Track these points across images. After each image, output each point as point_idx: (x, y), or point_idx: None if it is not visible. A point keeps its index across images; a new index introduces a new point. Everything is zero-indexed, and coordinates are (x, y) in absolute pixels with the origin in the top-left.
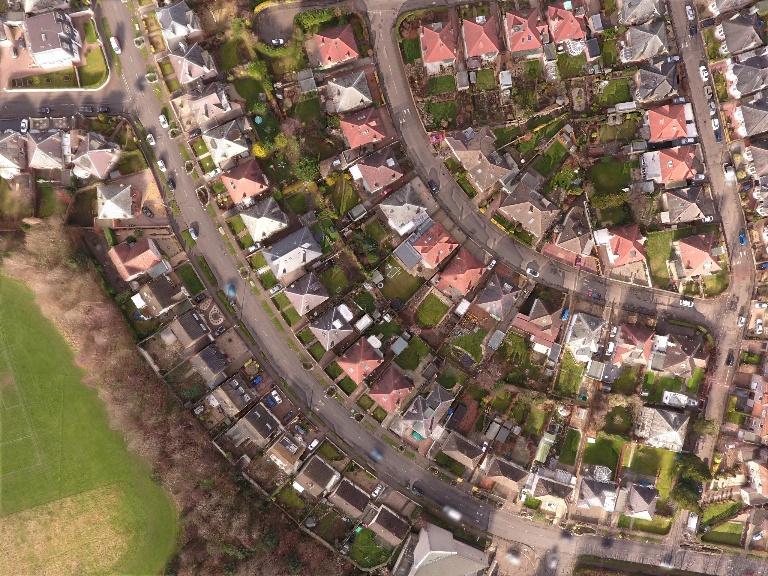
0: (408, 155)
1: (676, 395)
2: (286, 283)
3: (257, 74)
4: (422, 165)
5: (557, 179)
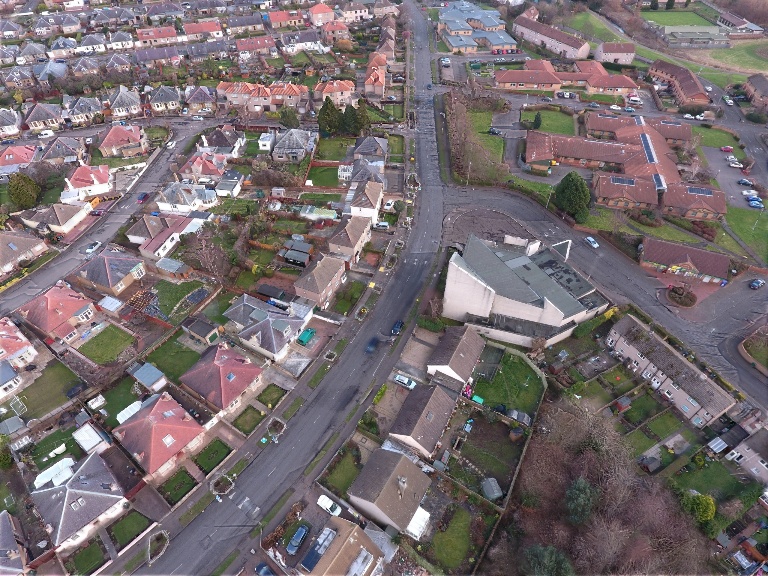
0: None
1: (260, 139)
2: None
3: None
4: None
5: None
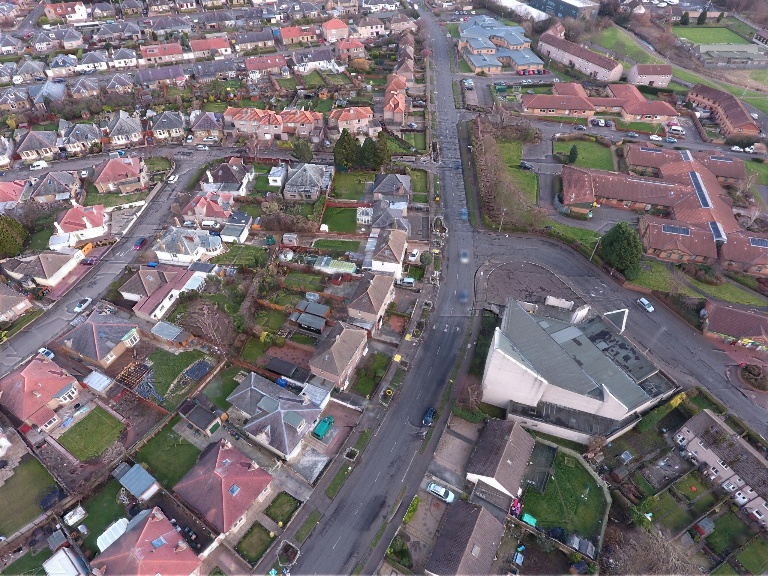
0: None
1: (270, 173)
2: None
3: None
4: None
5: None
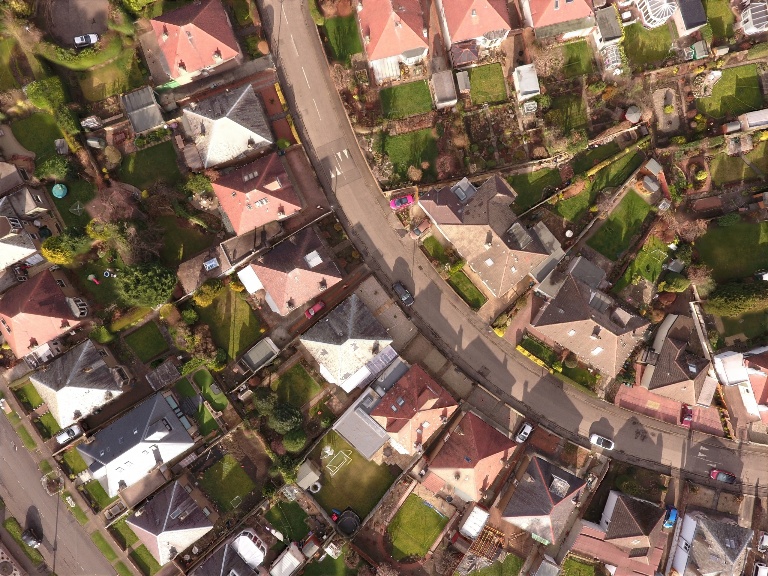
0: (351, 237)
1: None
2: (129, 503)
3: (47, 104)
4: (379, 253)
5: (638, 265)
